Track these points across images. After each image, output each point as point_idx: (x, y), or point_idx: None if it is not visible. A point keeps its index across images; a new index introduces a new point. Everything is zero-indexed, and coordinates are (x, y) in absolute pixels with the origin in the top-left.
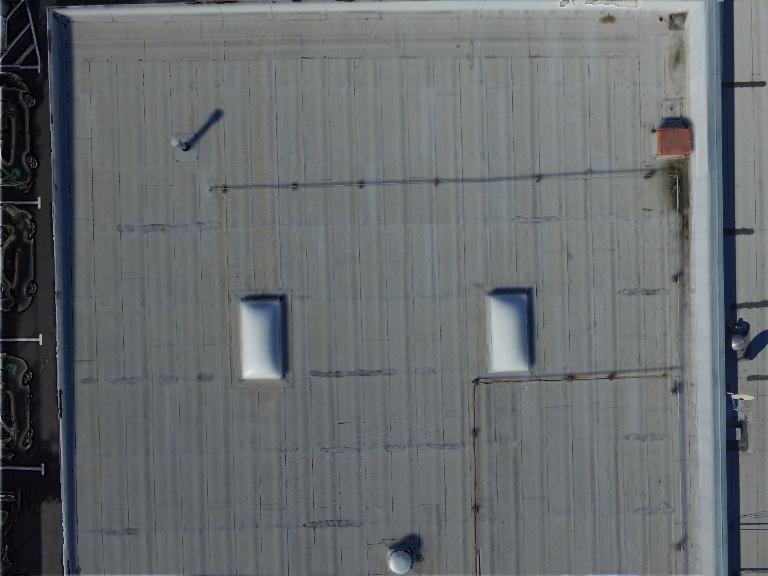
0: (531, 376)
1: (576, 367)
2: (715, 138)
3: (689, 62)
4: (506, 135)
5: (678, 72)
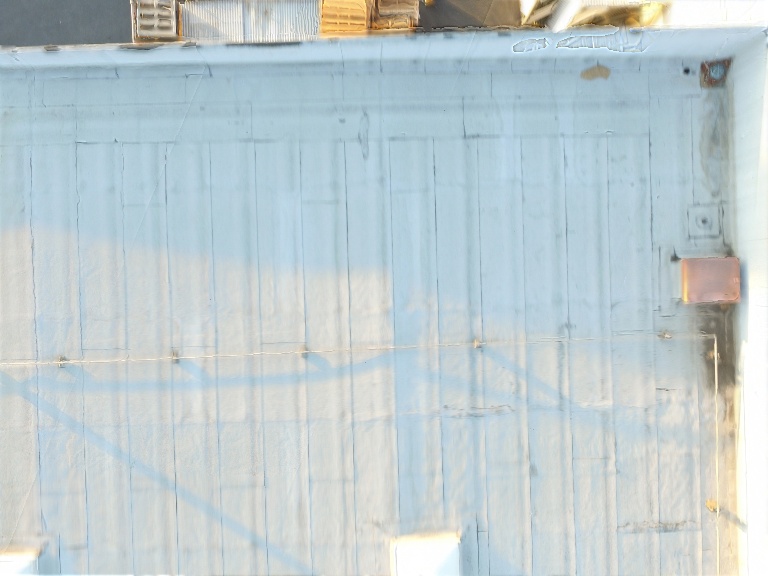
0: None
1: None
2: None
3: (734, 143)
4: (425, 270)
5: (715, 158)
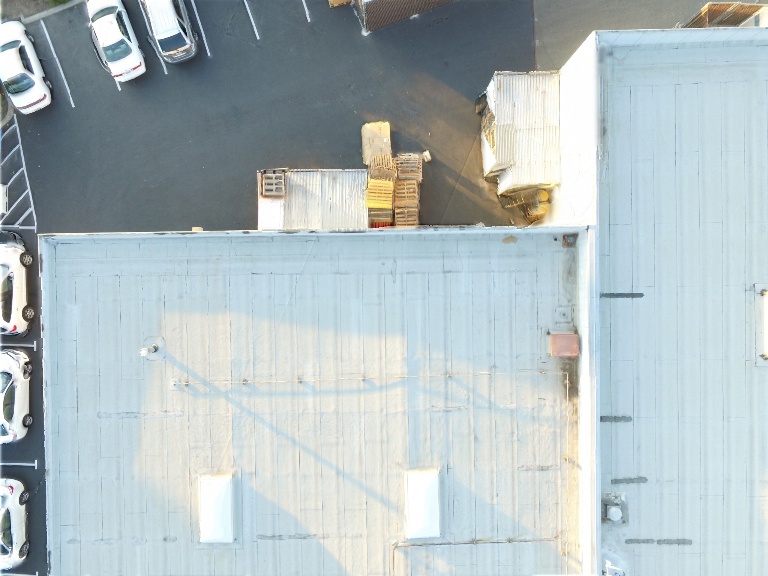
0: (442, 540)
1: (481, 532)
2: (594, 350)
3: (579, 276)
4: (423, 338)
5: (570, 283)
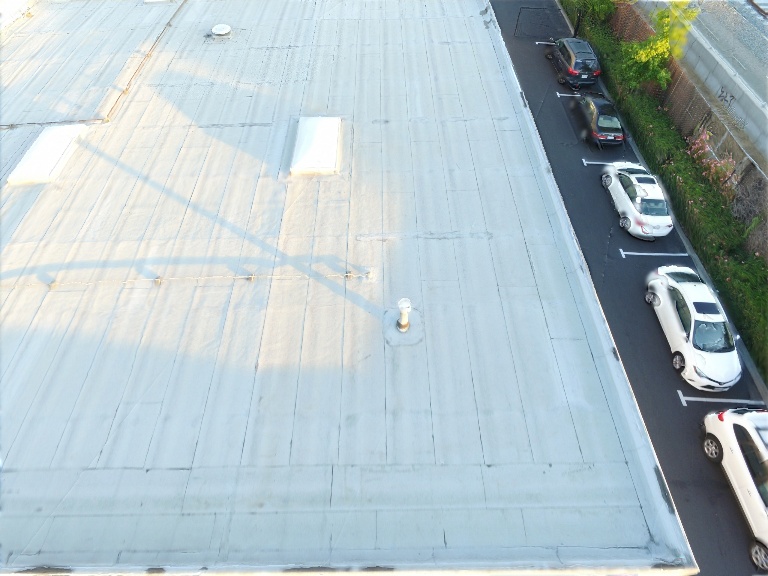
0: None
1: None
2: None
3: None
4: None
5: None
